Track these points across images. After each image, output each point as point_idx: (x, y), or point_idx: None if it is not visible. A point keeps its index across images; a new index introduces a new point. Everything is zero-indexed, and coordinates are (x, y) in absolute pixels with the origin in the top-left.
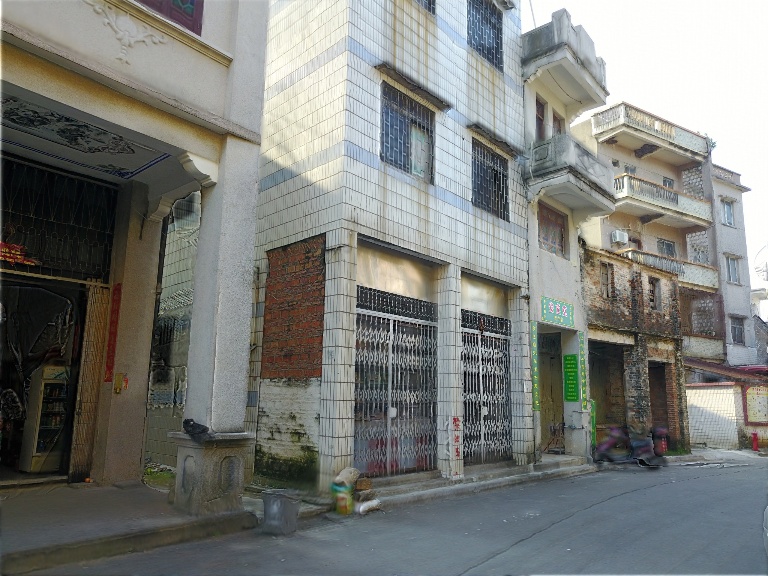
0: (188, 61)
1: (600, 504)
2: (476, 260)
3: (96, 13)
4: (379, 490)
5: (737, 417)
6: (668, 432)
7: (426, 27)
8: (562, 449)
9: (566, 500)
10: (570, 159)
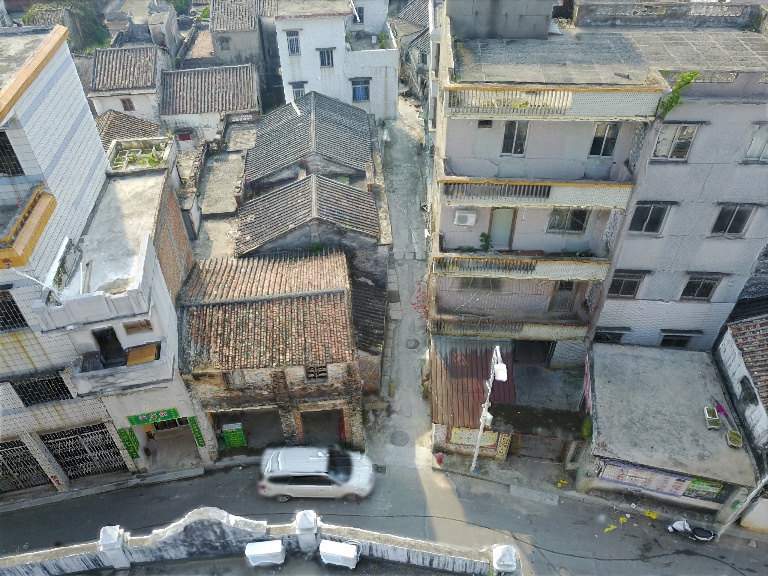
0: None
1: None
2: (43, 425)
3: None
4: (10, 499)
5: (437, 437)
6: None
7: None
8: None
9: (73, 531)
10: (82, 390)
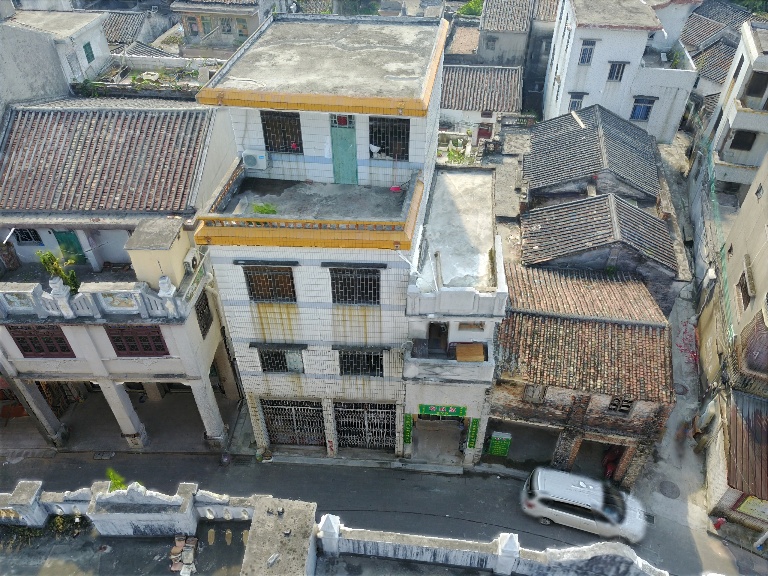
0: (168, 362)
1: (333, 512)
2: (345, 395)
3: (137, 362)
4: (286, 451)
5: (723, 501)
6: (614, 471)
7: (288, 312)
8: (463, 449)
9: (341, 497)
10: (408, 374)
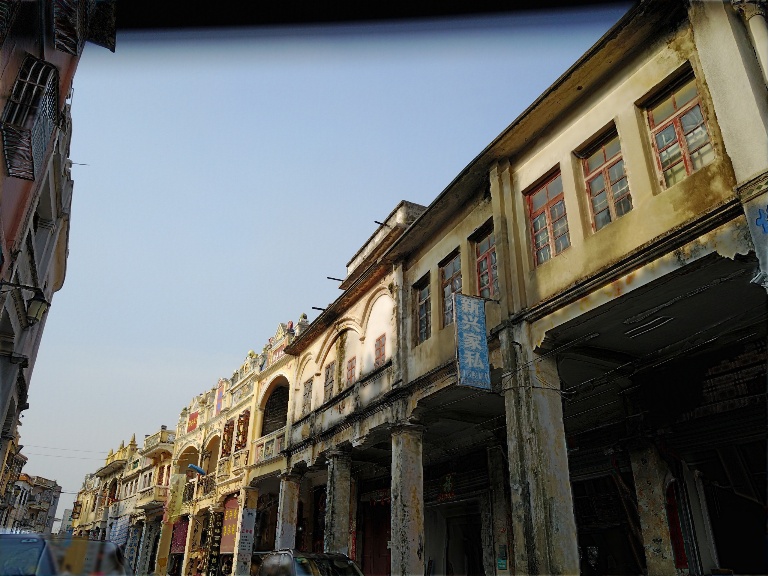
0: None
1: None
2: None
3: None
4: None
5: None
6: None
7: None
8: None
9: None
10: None
